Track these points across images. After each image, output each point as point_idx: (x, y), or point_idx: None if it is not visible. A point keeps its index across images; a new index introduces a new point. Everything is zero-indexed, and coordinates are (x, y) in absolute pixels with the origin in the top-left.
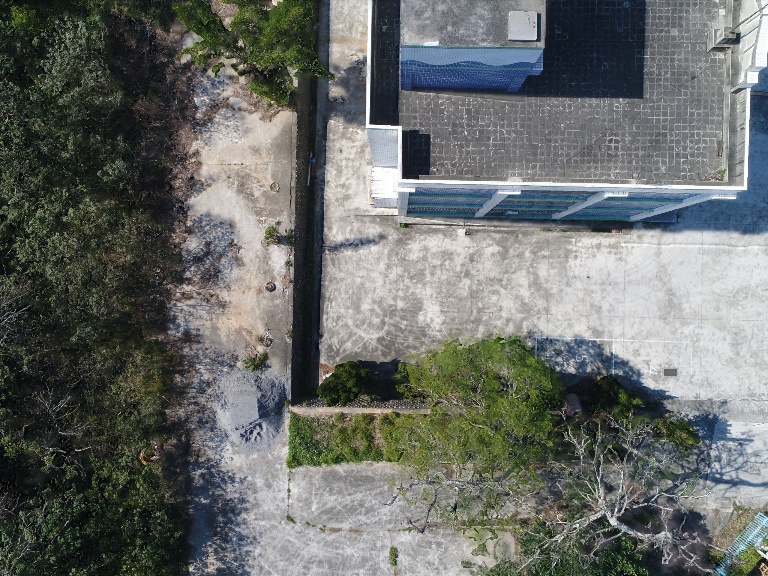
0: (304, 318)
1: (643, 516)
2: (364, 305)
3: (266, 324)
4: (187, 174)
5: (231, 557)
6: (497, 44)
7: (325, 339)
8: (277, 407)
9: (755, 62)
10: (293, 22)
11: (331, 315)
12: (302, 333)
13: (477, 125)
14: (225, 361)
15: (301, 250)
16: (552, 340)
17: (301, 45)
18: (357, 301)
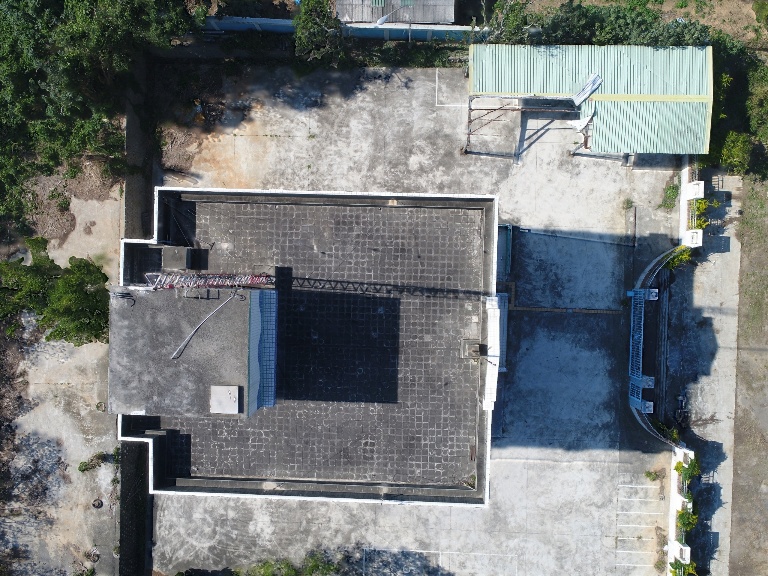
0: (137, 526)
1: None
2: (196, 514)
3: (93, 540)
4: (15, 393)
5: None
6: (201, 415)
7: (158, 547)
8: None
9: (485, 397)
10: (70, 304)
11: (164, 523)
12: (135, 541)
13: (236, 426)
14: None
15: (132, 462)
16: (380, 551)
17: (91, 312)
18: (189, 510)
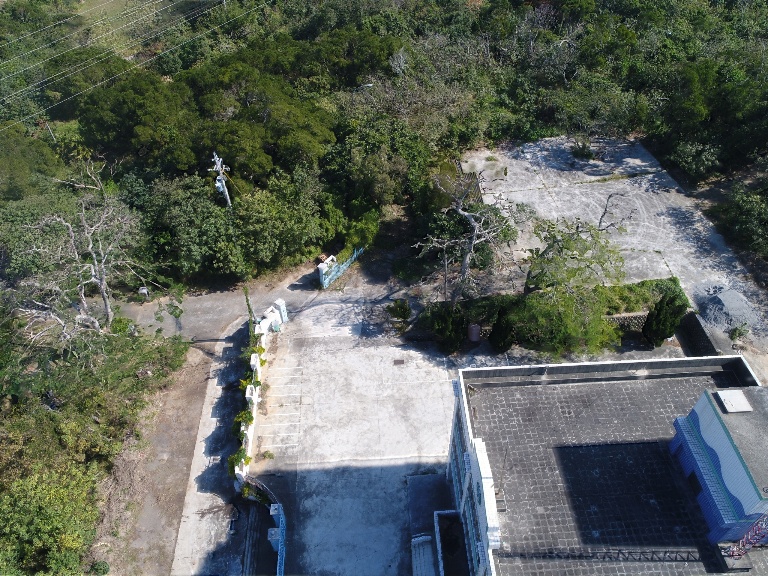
0: None
1: (409, 278)
2: None
3: None
4: None
5: (688, 231)
6: (748, 389)
7: None
8: (705, 307)
9: None
10: None
11: None
12: None
13: None
14: (762, 332)
15: None
16: None
17: None
18: None
